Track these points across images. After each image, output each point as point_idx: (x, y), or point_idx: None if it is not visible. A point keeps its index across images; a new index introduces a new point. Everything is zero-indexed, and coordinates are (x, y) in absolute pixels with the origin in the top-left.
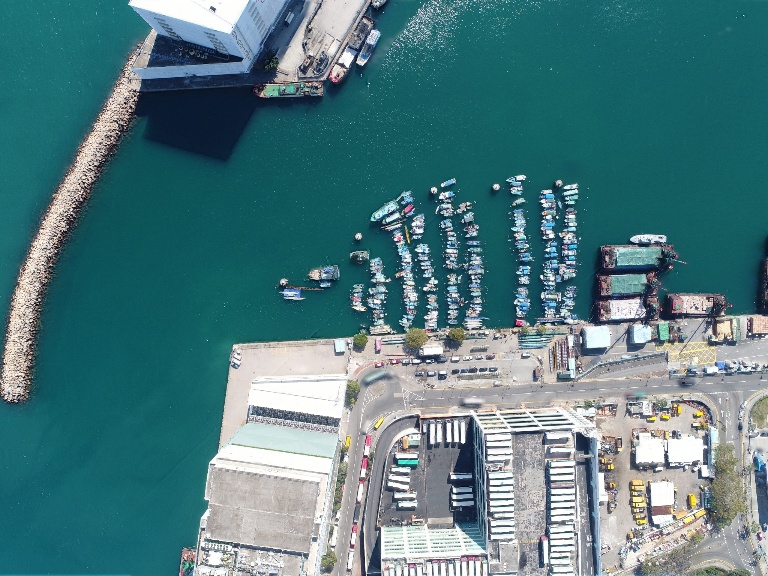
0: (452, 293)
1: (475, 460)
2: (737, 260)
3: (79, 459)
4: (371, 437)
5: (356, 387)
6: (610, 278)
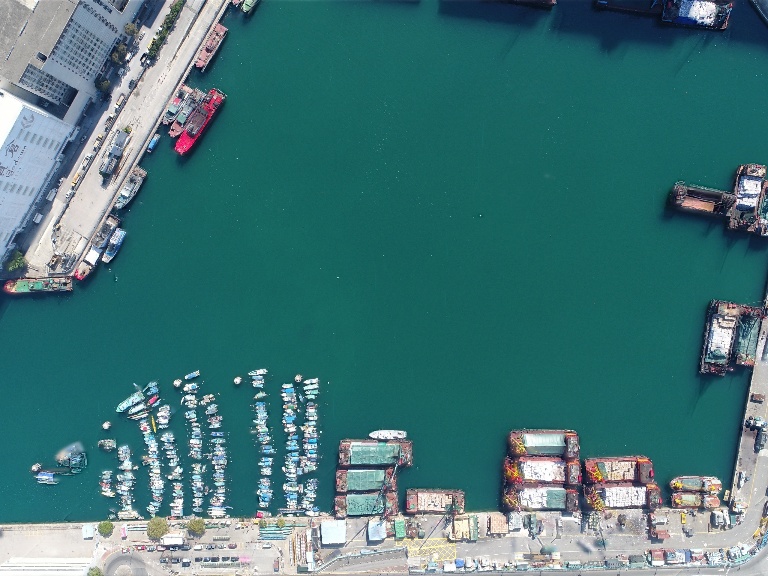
0: (197, 482)
1: None
2: (479, 456)
3: None
4: None
5: (96, 575)
6: (345, 475)
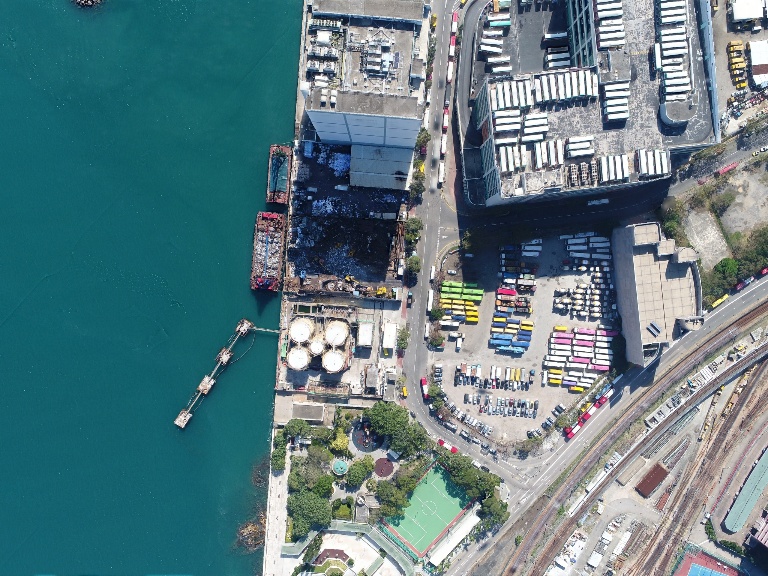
0: None
1: (570, 12)
2: None
3: (158, 61)
4: None
5: None
6: None
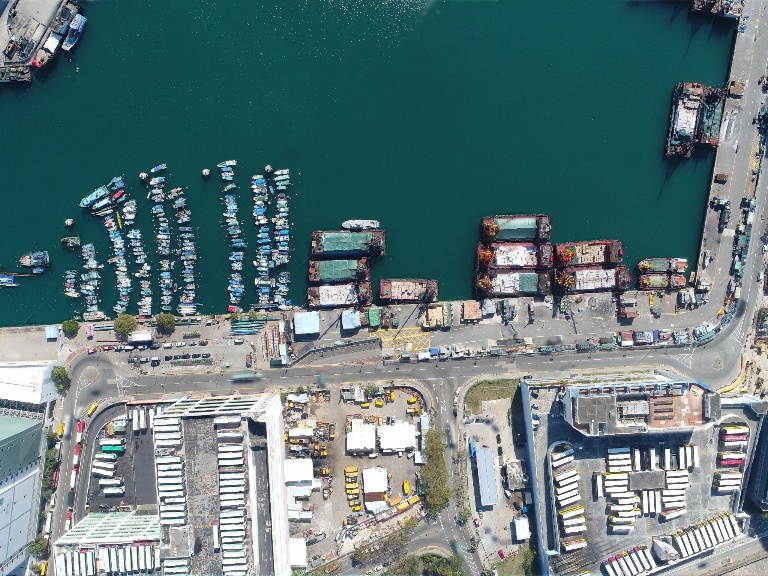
0: (165, 279)
1: None
2: (452, 245)
3: None
4: (85, 424)
5: (61, 373)
6: (318, 263)
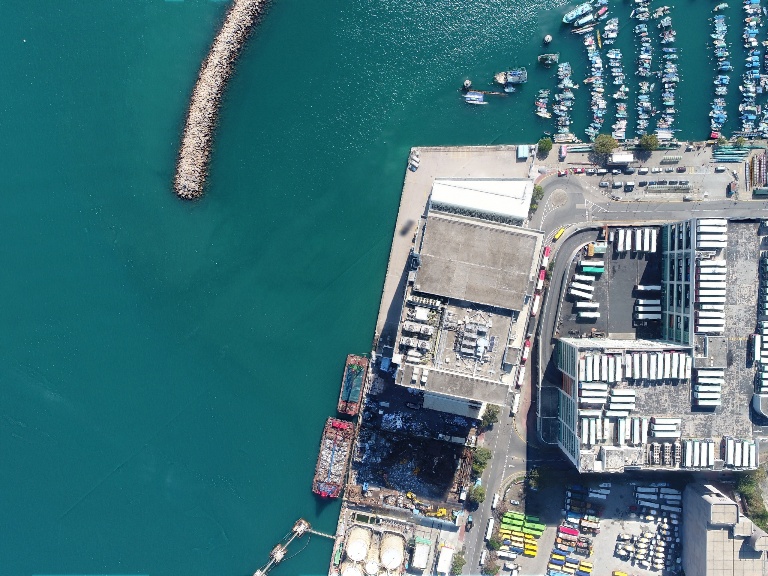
0: (643, 102)
1: (667, 268)
2: None
3: (248, 259)
4: None
5: (541, 190)
6: None
